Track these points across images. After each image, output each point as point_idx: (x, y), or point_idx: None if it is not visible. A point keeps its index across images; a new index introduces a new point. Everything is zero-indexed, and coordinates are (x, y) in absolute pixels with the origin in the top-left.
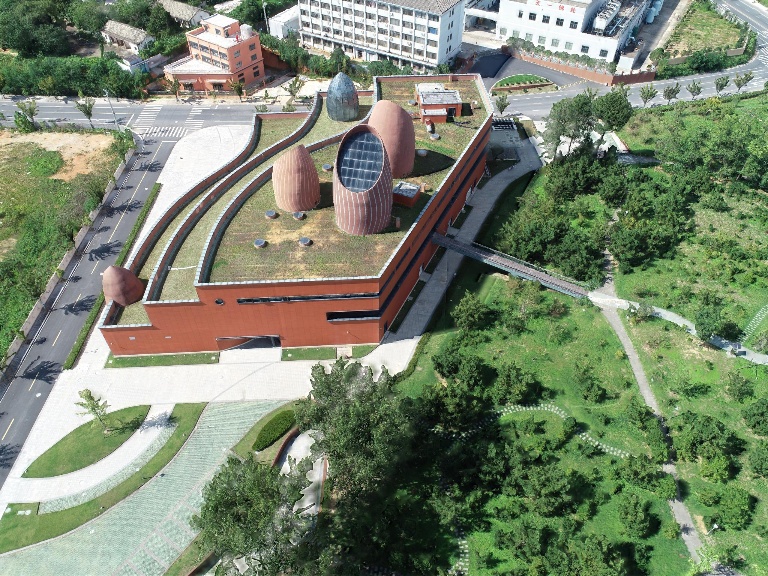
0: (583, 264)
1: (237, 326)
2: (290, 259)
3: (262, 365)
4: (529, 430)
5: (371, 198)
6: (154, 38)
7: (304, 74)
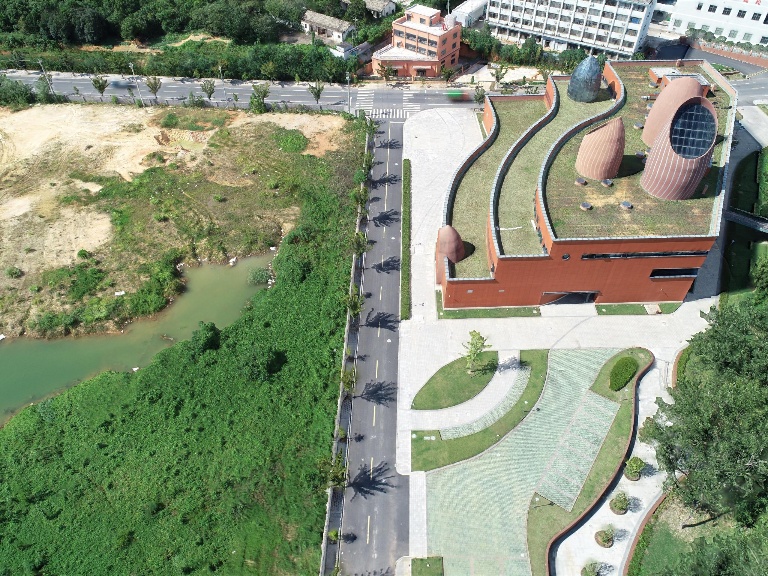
0: None
1: (567, 281)
2: (621, 220)
3: (582, 318)
4: None
5: (700, 164)
6: (355, 27)
7: (495, 62)
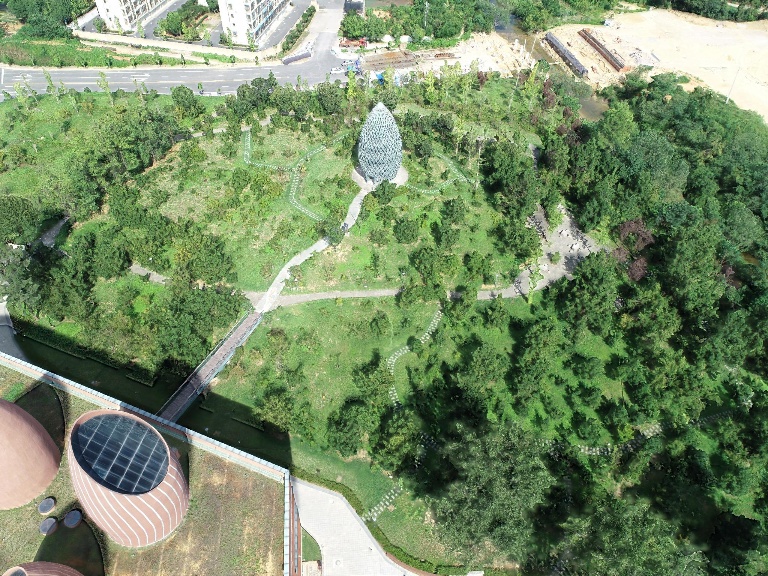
0: None
1: None
2: None
3: None
4: None
5: (174, 458)
6: None
7: None
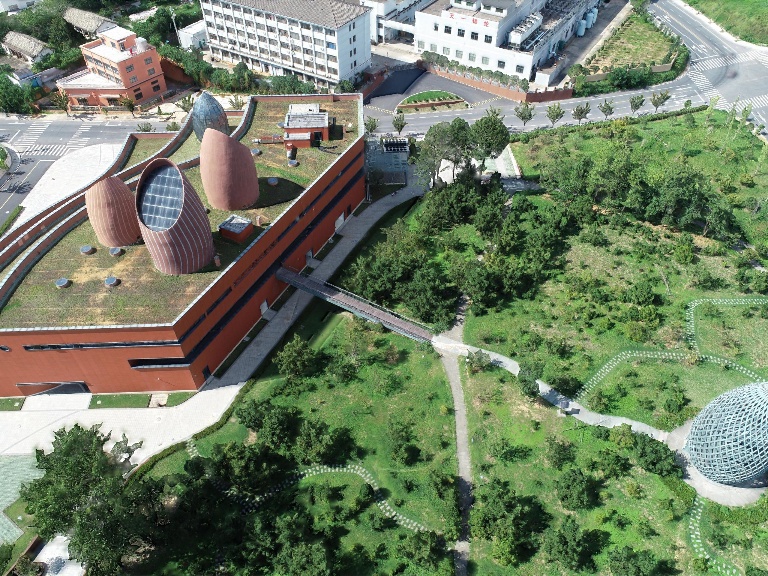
0: (430, 305)
1: (34, 372)
2: (89, 301)
3: (66, 413)
4: (322, 497)
5: (174, 237)
6: (52, 50)
7: (208, 88)
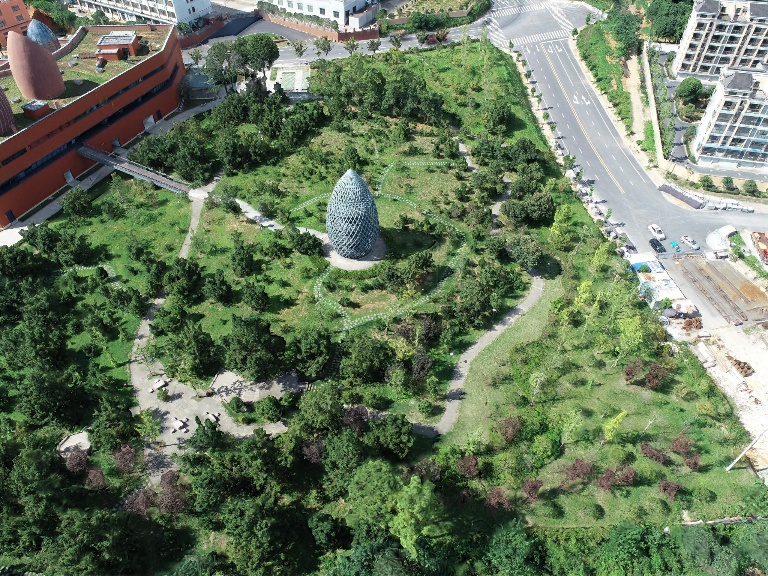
0: None
1: None
2: None
3: None
4: (71, 279)
5: None
6: None
7: (72, 34)
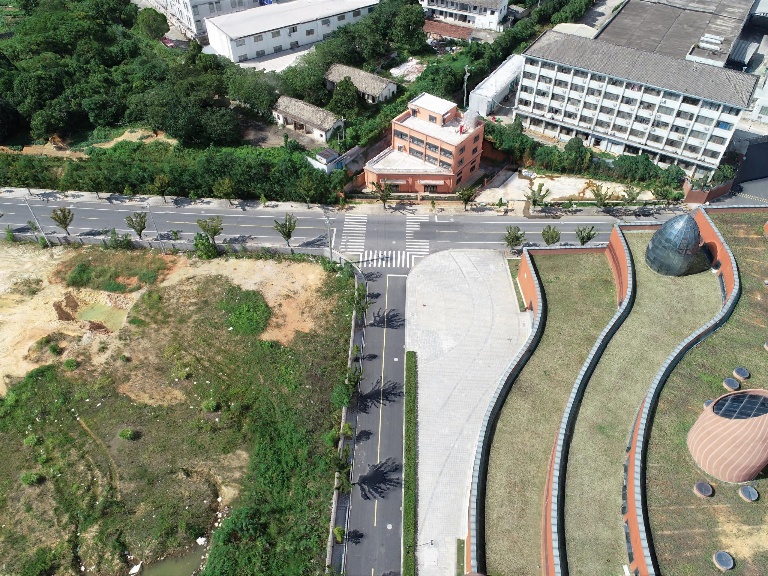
0: None
1: None
2: None
3: None
4: None
5: None
6: None
7: (528, 168)
